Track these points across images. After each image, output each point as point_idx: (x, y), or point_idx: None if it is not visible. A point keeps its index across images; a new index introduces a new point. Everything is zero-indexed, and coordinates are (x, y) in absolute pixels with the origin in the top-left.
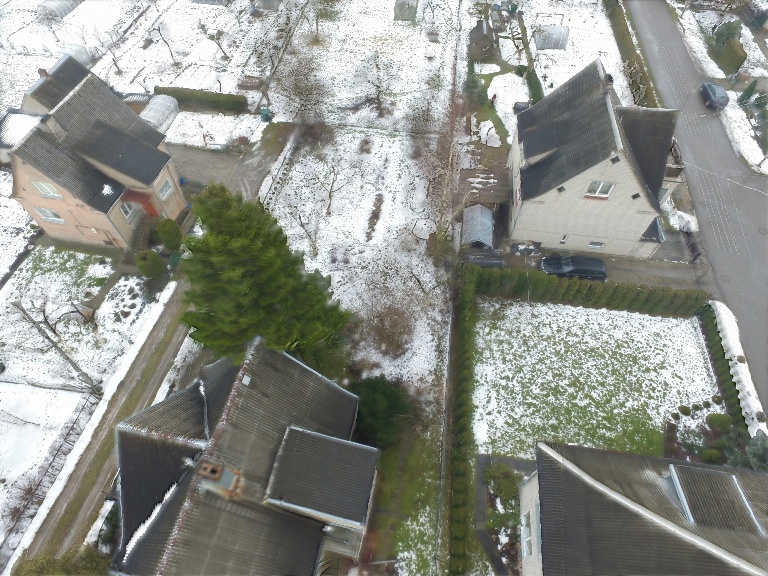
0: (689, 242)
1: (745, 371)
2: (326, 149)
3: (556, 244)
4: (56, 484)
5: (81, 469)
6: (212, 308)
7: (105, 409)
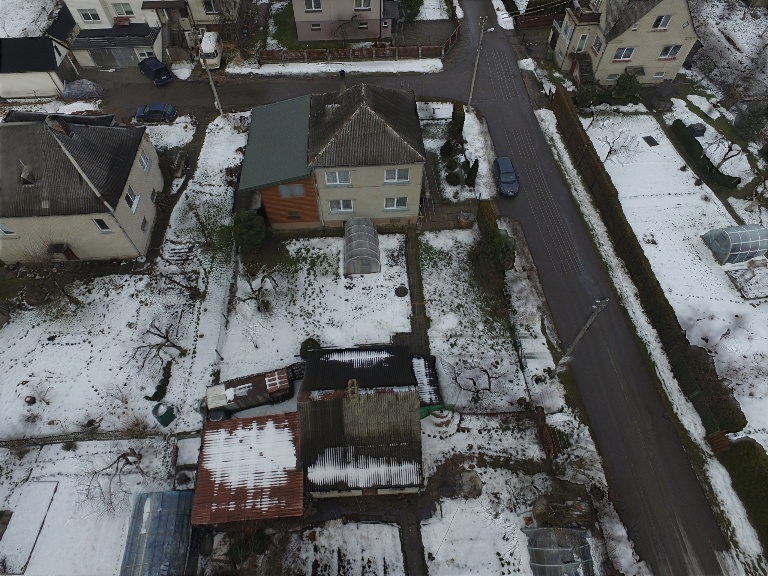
0: (526, 49)
1: (497, 6)
2: None
3: None
4: None
5: None
6: None
7: None
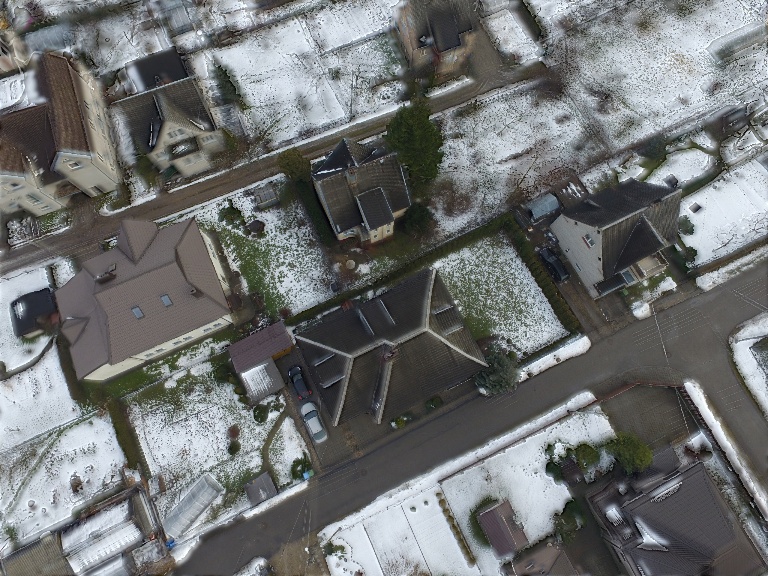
0: None
1: (552, 363)
2: (542, 100)
3: (564, 249)
4: (315, 136)
5: (325, 139)
6: (393, 131)
7: (347, 127)
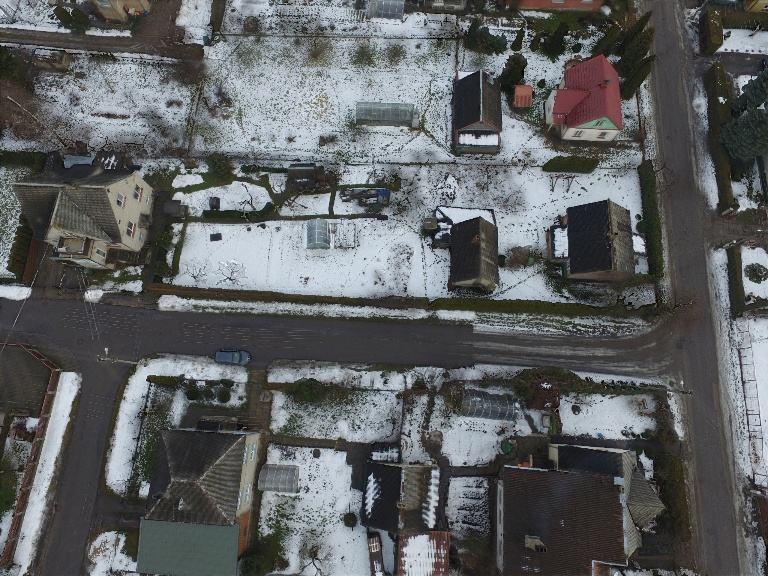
0: None
1: None
2: (173, 82)
3: None
4: None
5: None
6: None
7: (5, 27)
